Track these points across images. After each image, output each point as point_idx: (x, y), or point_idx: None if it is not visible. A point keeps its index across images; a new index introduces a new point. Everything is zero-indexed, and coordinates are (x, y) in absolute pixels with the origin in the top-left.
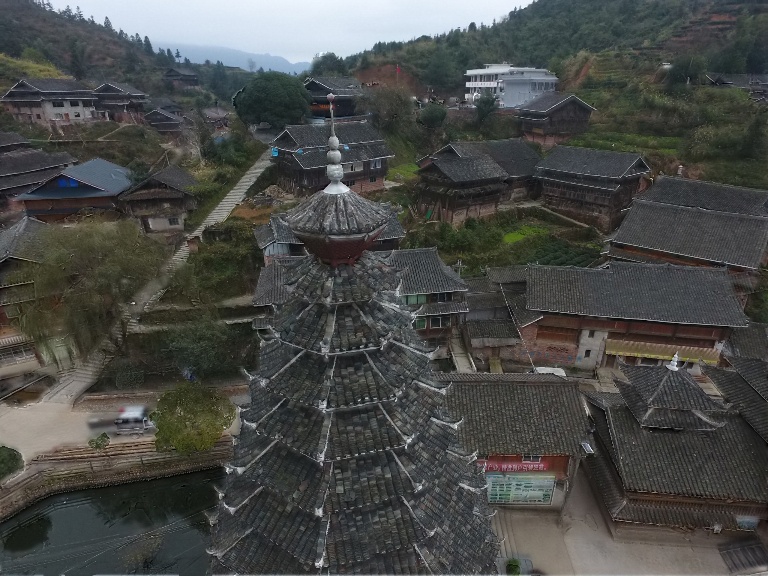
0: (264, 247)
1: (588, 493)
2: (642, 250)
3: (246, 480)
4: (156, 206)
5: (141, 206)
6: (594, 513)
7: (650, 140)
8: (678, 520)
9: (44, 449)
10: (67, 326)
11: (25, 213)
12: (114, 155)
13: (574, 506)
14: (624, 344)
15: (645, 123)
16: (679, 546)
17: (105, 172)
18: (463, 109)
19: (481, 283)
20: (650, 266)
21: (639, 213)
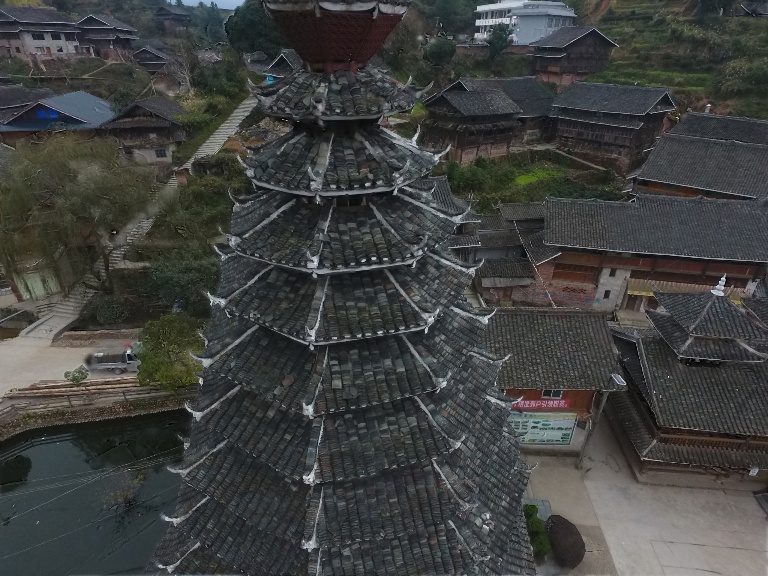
0: None
1: (609, 434)
2: (668, 187)
3: (218, 383)
4: (141, 136)
5: (125, 136)
6: (616, 454)
7: (676, 78)
8: (714, 460)
9: (19, 383)
10: (37, 249)
11: None
12: (100, 94)
13: (594, 447)
14: (648, 283)
15: (672, 59)
16: (710, 489)
17: (88, 105)
18: (474, 47)
19: (493, 220)
20: (681, 199)
21: (667, 148)
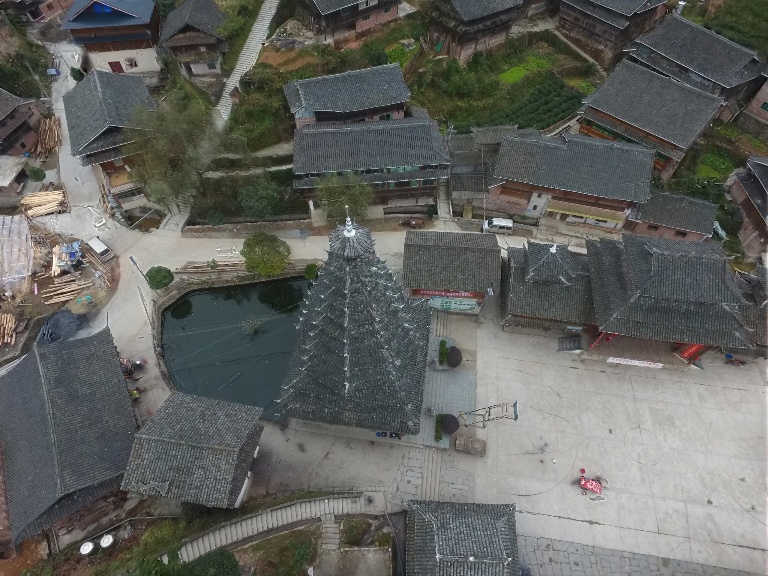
0: (295, 112)
1: (500, 304)
2: None
3: None
4: (193, 49)
5: (181, 49)
6: (499, 316)
7: None
8: (536, 326)
9: (176, 263)
10: (175, 192)
11: (73, 41)
12: None
13: (489, 311)
14: (561, 204)
15: None
16: (538, 335)
17: None
18: None
19: (468, 142)
20: (598, 144)
21: (621, 76)
